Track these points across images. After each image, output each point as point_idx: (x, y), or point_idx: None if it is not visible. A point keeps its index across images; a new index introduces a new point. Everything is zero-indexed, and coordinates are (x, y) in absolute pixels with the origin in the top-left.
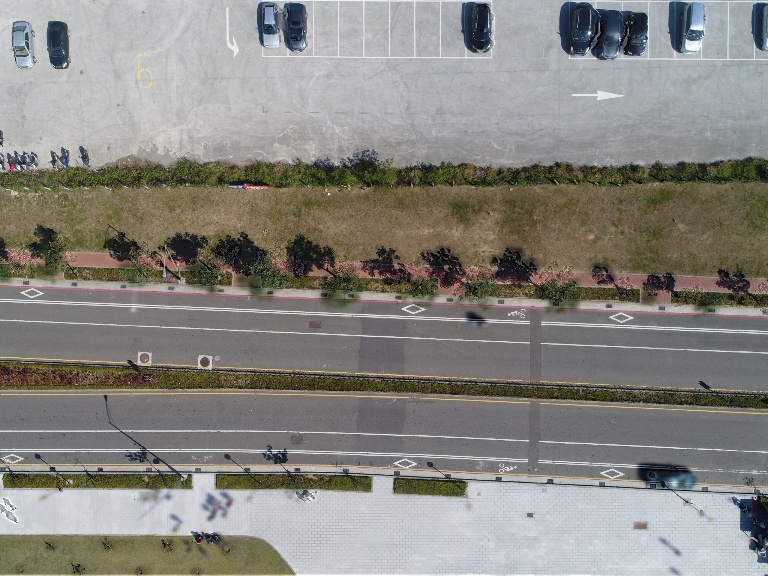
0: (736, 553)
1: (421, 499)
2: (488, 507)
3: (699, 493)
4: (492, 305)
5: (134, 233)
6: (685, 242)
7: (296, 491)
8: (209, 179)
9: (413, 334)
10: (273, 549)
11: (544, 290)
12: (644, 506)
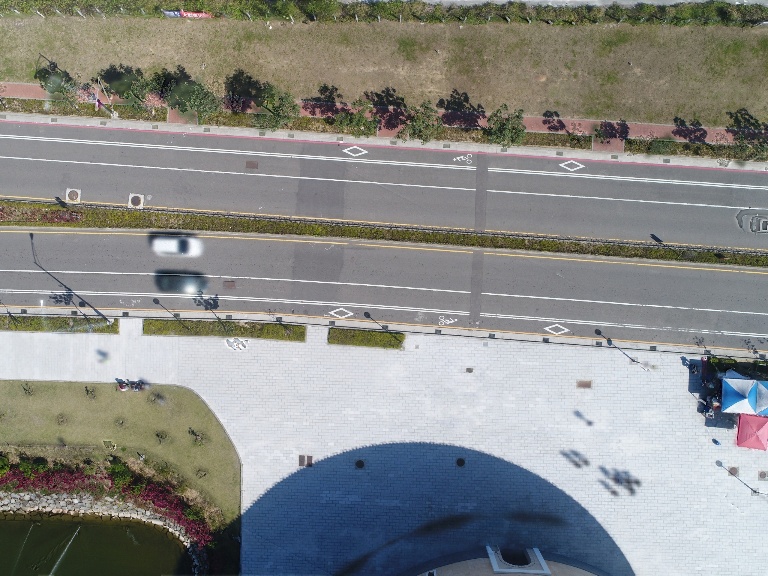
0: (683, 415)
1: (356, 351)
2: (426, 361)
3: (647, 352)
4: (437, 149)
5: (66, 63)
6: (641, 87)
7: (226, 339)
8: (146, 7)
9: (354, 177)
10: (200, 399)
11: (492, 134)
12: (589, 364)
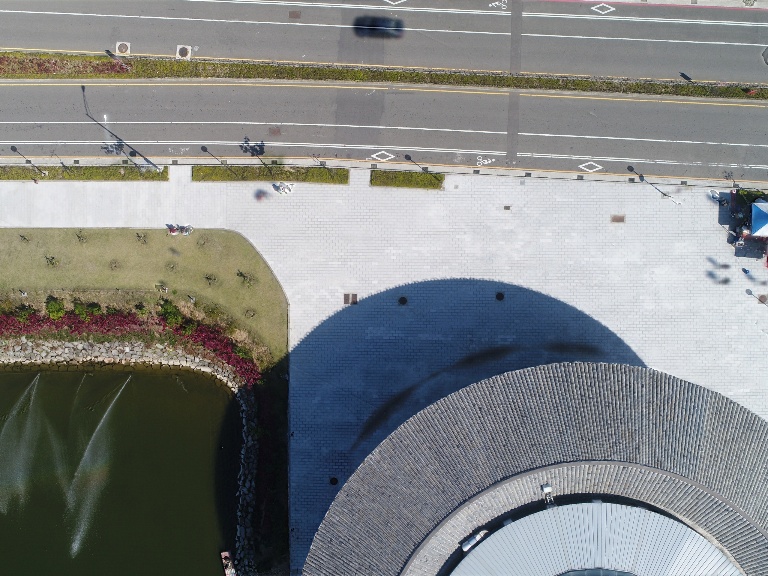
0: (714, 247)
1: (398, 192)
2: (465, 200)
3: (678, 186)
4: None
5: None
6: None
7: (272, 183)
8: None
9: (393, 25)
10: (248, 242)
11: None
12: (622, 199)
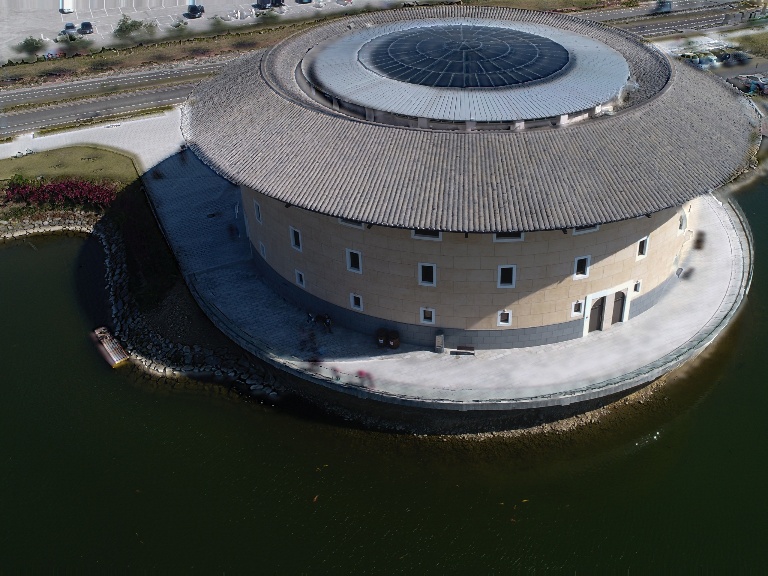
0: None
1: None
2: None
3: None
4: None
5: None
6: None
7: None
8: None
9: None
10: None
11: None
12: None
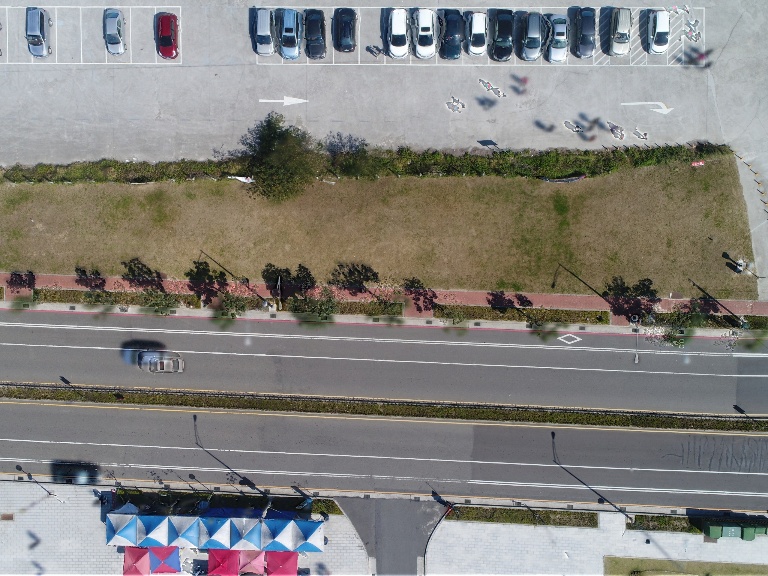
0: (96, 543)
1: None
2: None
3: (62, 485)
4: None
5: None
6: (43, 241)
7: None
8: None
9: None
10: None
11: None
12: (11, 498)
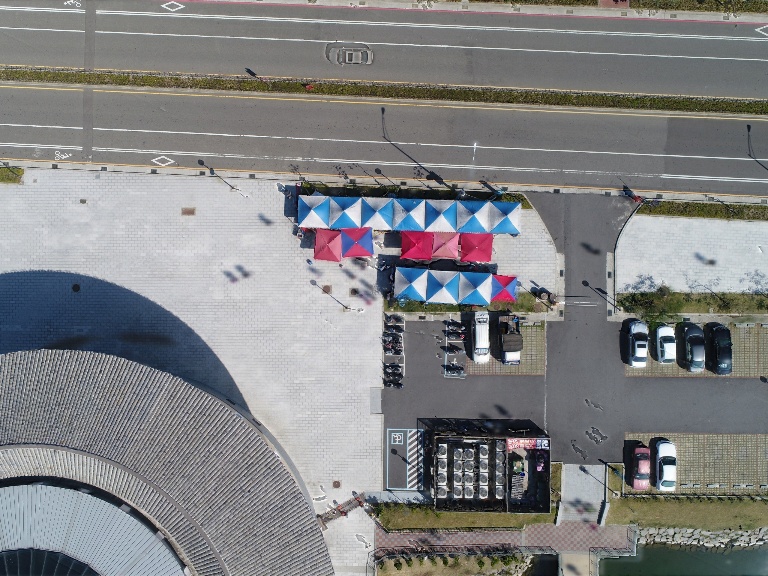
0: (280, 238)
1: None
2: (43, 193)
3: (245, 179)
4: None
5: None
6: None
7: None
8: None
9: None
10: None
11: None
12: (192, 192)
